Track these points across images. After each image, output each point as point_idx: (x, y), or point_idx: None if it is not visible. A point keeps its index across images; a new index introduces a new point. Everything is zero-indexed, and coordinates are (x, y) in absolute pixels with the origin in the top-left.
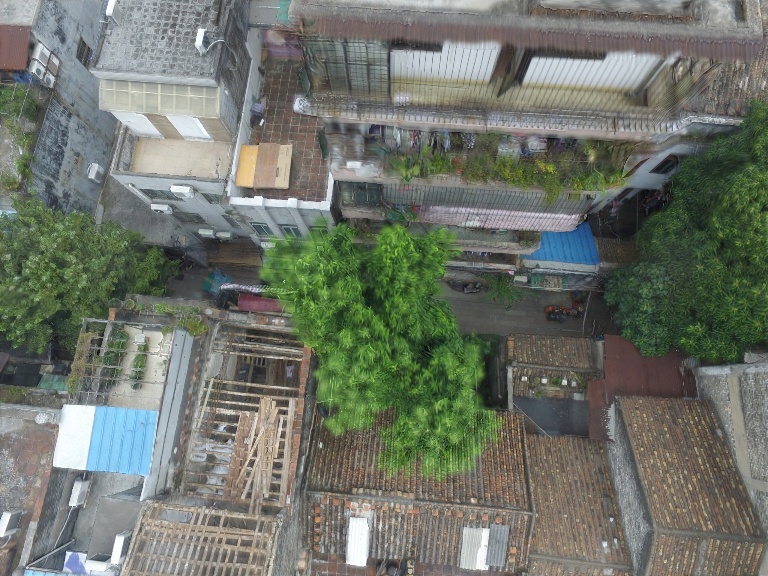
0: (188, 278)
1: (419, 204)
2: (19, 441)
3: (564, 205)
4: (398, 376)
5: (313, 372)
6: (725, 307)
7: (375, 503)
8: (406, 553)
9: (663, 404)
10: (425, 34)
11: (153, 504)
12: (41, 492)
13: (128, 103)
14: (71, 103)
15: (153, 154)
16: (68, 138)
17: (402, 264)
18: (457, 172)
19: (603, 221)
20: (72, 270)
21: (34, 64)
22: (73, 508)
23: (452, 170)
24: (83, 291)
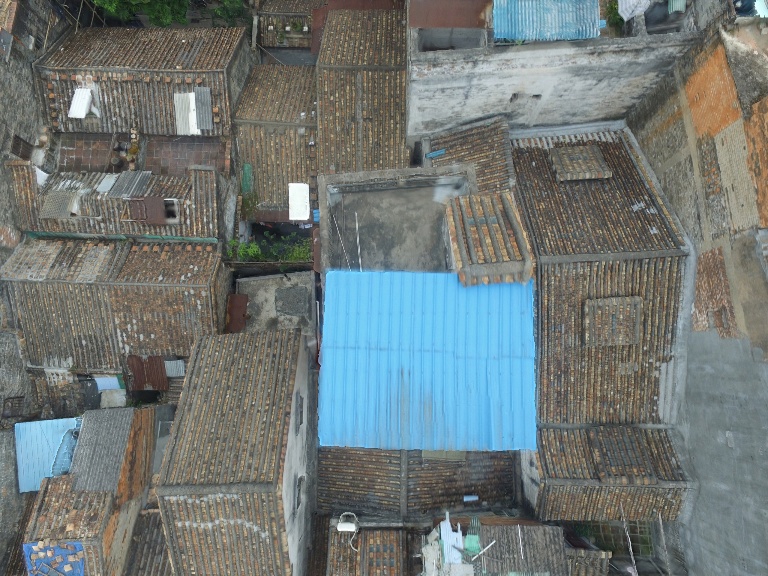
0: None
1: None
2: None
3: None
4: None
5: None
6: None
7: (96, 74)
8: (132, 125)
9: (365, 12)
10: None
11: None
12: None
13: None
14: None
15: None
16: None
17: None
18: None
19: None
20: None
21: None
22: None
23: None
24: None
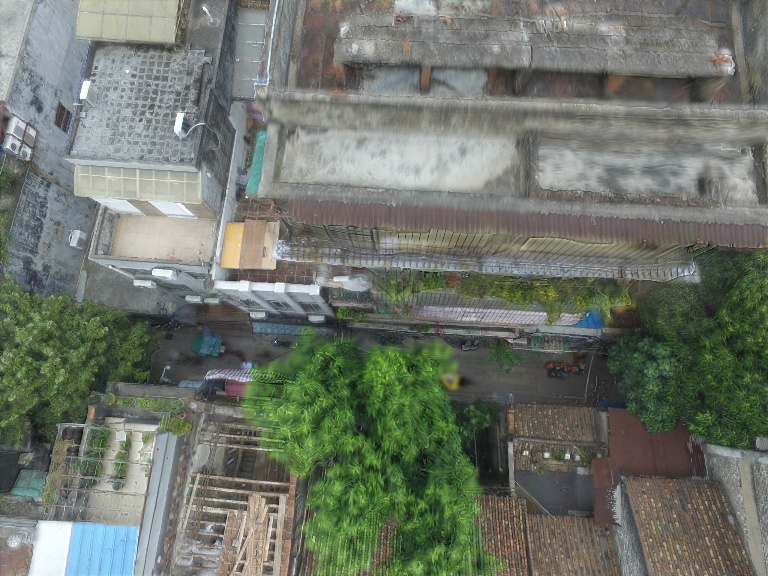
0: (177, 337)
1: (412, 305)
2: None
3: (565, 307)
4: (392, 504)
5: None
6: (736, 401)
7: None
8: None
9: (671, 487)
10: (411, 215)
11: None
12: None
13: (105, 189)
14: (50, 172)
15: (134, 232)
16: (47, 208)
17: (394, 387)
18: None
19: None
20: (49, 364)
21: (8, 139)
22: None
23: (446, 287)
24: (61, 383)
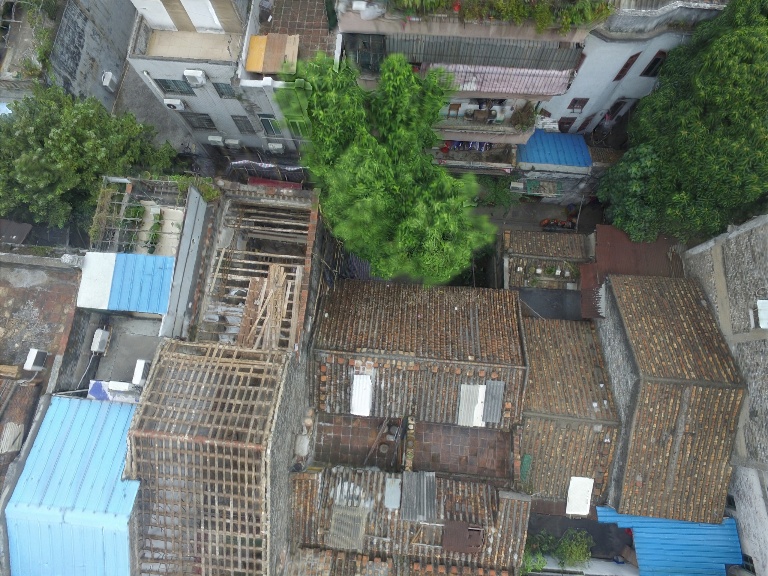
0: None
1: (420, 60)
2: (43, 293)
3: (555, 57)
4: (400, 202)
5: (319, 243)
6: (707, 167)
7: (378, 361)
8: (407, 411)
9: (651, 281)
10: None
11: (171, 341)
12: (66, 330)
13: None
14: (87, 8)
15: (167, 45)
16: (84, 41)
17: (404, 94)
18: (455, 9)
19: (597, 141)
20: (92, 143)
21: None
22: (94, 355)
23: (450, 5)
24: (101, 167)
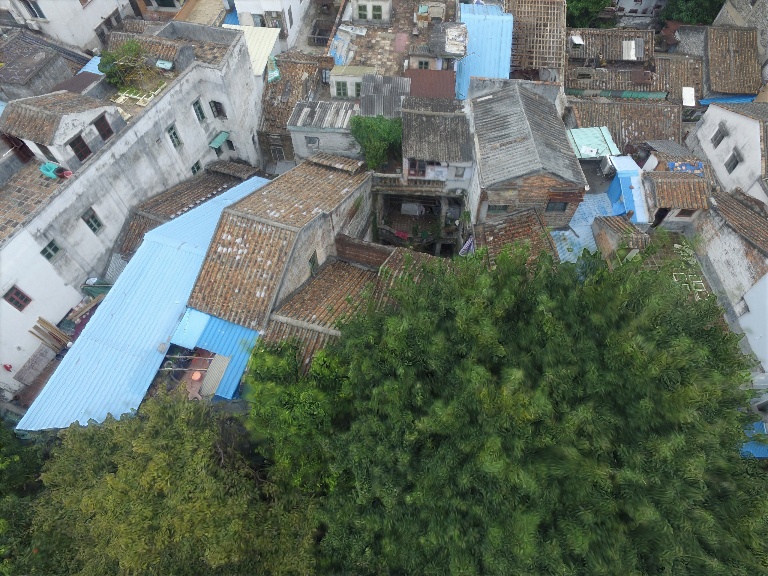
0: None
1: None
2: None
3: None
4: None
5: None
6: None
7: (582, 31)
8: (597, 55)
9: None
10: None
11: None
12: None
13: None
14: None
15: None
16: None
17: None
18: None
19: None
20: None
21: None
22: None
23: None
24: None
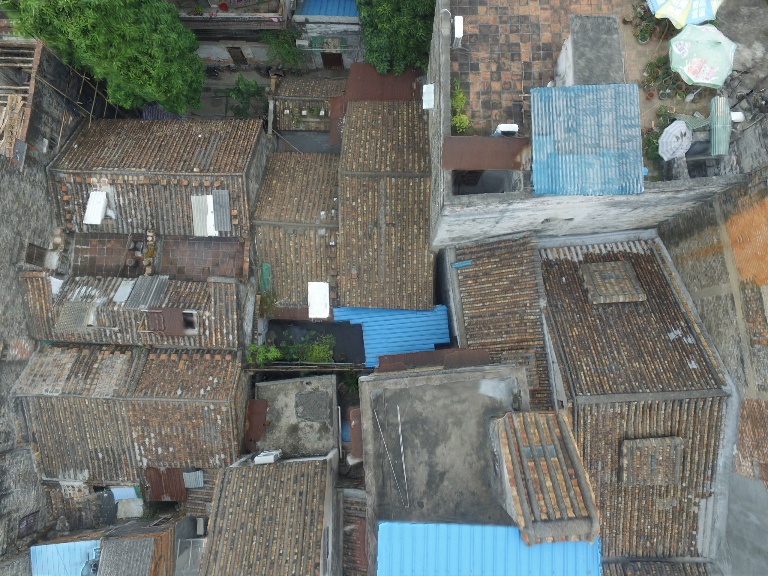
0: None
1: None
2: None
3: None
4: None
5: (59, 76)
6: None
7: (111, 177)
8: (148, 226)
9: (385, 104)
10: None
11: None
12: None
13: None
14: None
15: None
16: None
17: None
18: None
19: None
20: None
21: None
22: None
23: None
24: None
